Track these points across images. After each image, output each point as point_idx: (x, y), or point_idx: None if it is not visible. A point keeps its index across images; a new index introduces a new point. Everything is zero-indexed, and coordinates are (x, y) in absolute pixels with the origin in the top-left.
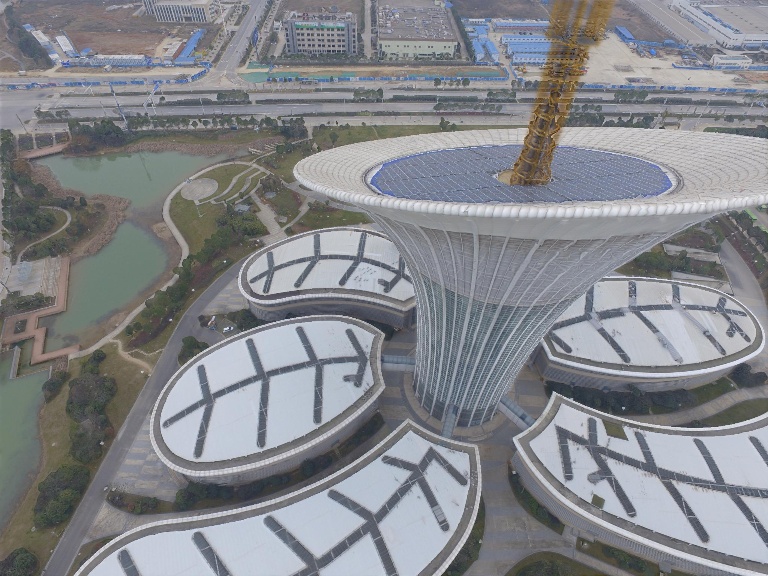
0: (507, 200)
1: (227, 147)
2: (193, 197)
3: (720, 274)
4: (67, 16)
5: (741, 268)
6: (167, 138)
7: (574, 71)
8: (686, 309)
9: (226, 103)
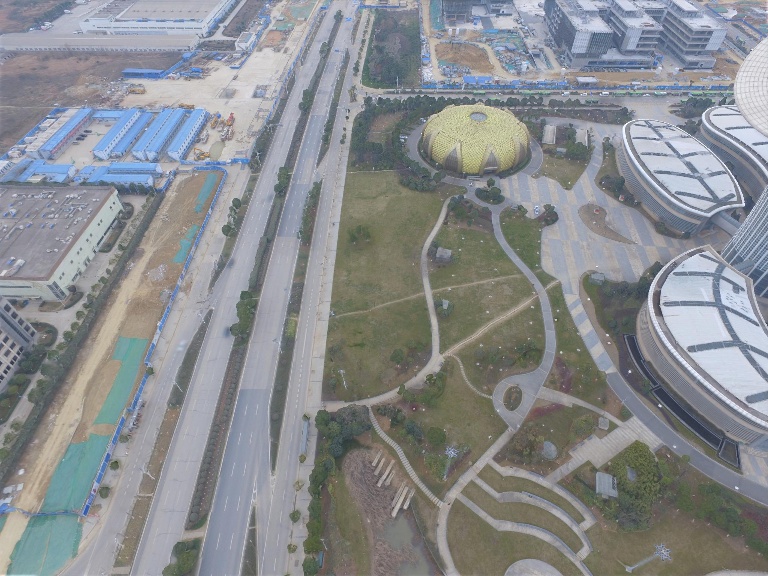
0: None
1: (386, 568)
2: None
3: None
4: None
5: (556, 120)
6: None
7: (229, 121)
8: None
9: None
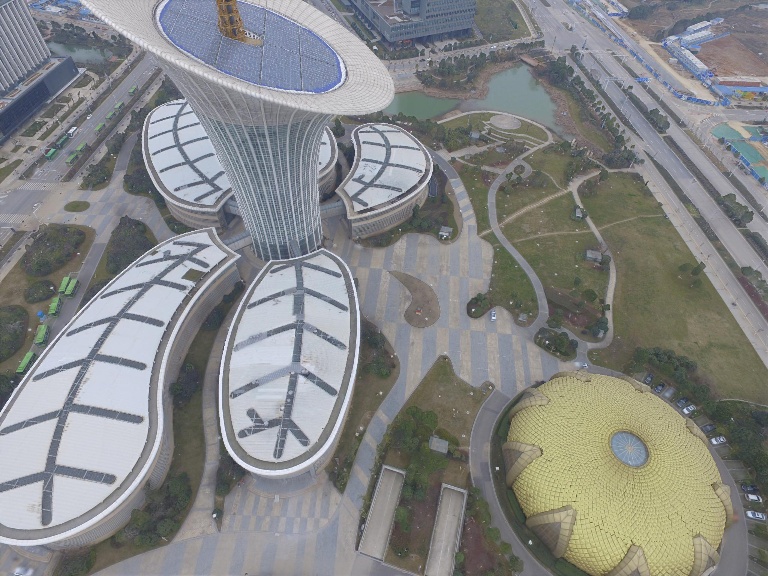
0: (198, 8)
1: (572, 128)
2: (494, 120)
3: (399, 549)
4: (763, 29)
5: None
6: (572, 100)
7: None
8: (291, 376)
9: (651, 120)
